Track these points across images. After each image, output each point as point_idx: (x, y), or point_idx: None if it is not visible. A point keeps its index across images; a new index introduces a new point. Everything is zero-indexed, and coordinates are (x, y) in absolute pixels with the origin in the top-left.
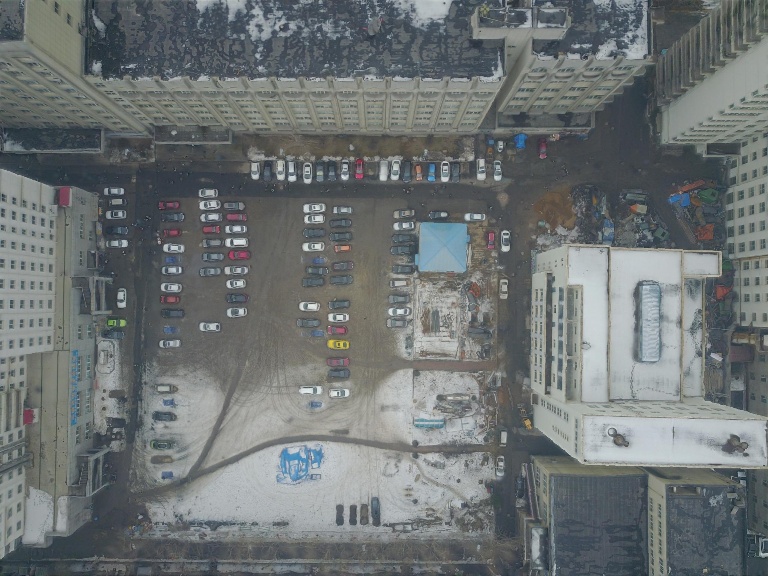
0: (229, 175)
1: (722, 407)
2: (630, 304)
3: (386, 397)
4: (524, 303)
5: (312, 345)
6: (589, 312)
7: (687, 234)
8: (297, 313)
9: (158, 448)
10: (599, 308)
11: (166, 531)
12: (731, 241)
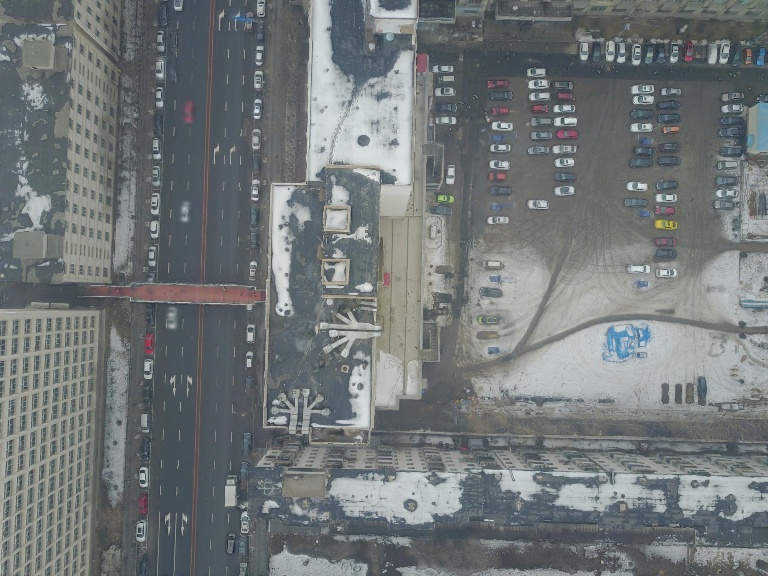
0: (556, 56)
1: None
2: None
3: (712, 278)
4: None
5: (638, 225)
6: None
7: None
8: (624, 193)
9: (487, 323)
10: None
11: (492, 405)
12: None
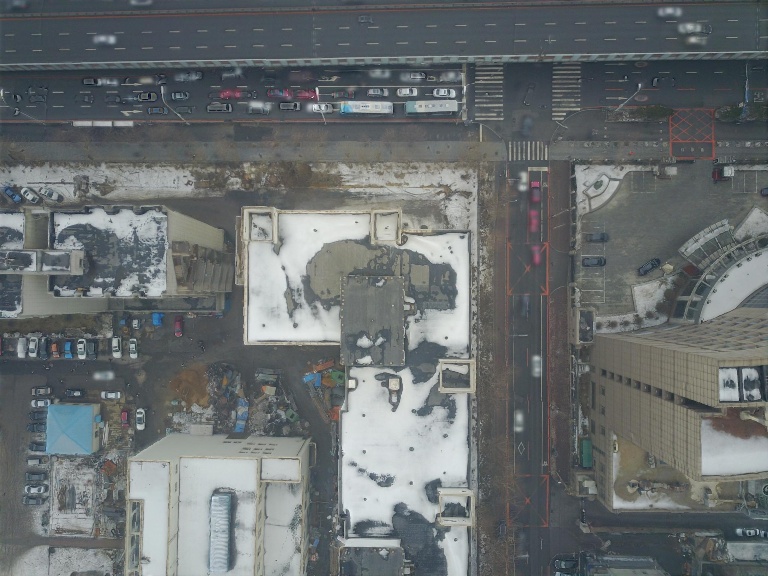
0: None
1: None
2: (206, 511)
3: (23, 573)
4: None
5: None
6: (151, 526)
7: (321, 414)
8: None
9: None
10: (161, 522)
11: None
12: None
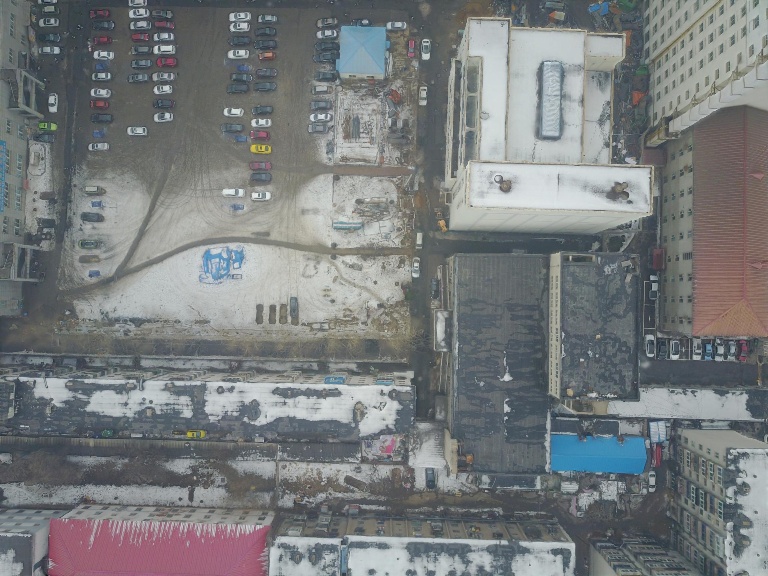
0: None
1: None
2: (533, 83)
3: (307, 201)
4: (443, 111)
5: (236, 150)
6: (489, 84)
7: None
8: (222, 119)
9: (85, 246)
10: (499, 80)
11: (92, 327)
12: (647, 46)
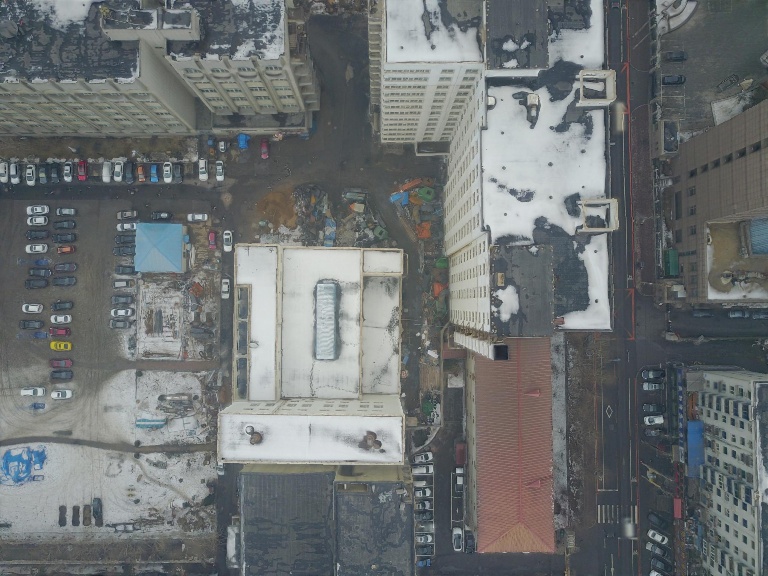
0: None
1: (390, 404)
2: (310, 302)
3: (109, 398)
4: None
5: (36, 347)
6: (258, 311)
7: (408, 232)
8: (21, 315)
9: None
10: (268, 307)
11: None
12: (445, 239)
